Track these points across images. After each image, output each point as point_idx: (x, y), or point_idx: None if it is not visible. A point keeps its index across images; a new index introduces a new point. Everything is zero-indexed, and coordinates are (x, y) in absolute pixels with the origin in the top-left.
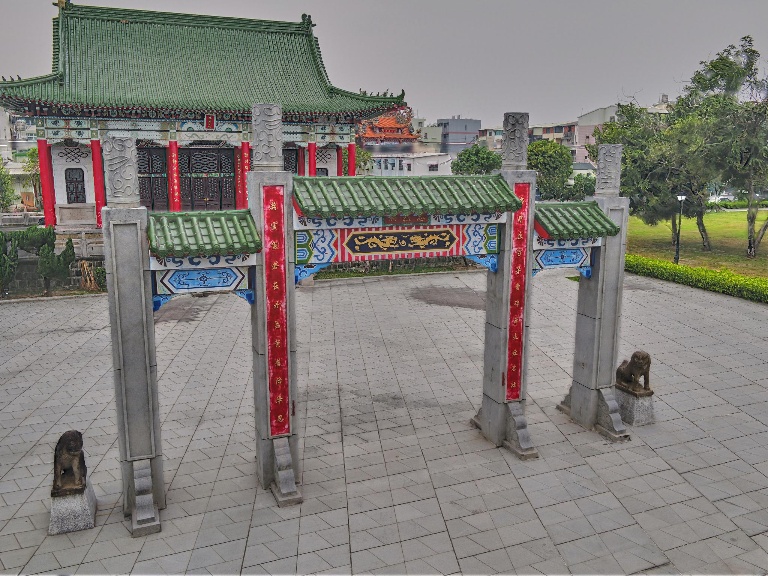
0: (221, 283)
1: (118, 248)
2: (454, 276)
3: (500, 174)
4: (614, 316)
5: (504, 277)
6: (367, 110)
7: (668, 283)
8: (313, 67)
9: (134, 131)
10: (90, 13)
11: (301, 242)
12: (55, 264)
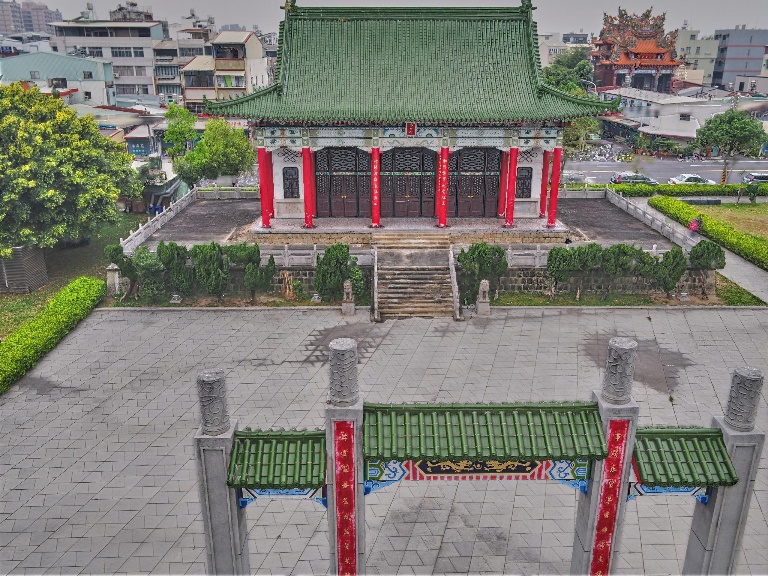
0: (298, 492)
1: (208, 466)
2: (647, 315)
3: (597, 403)
4: (731, 549)
5: (591, 505)
6: (576, 115)
7: None
8: (527, 59)
9: (340, 138)
10: (312, 14)
11: (373, 462)
12: (258, 280)
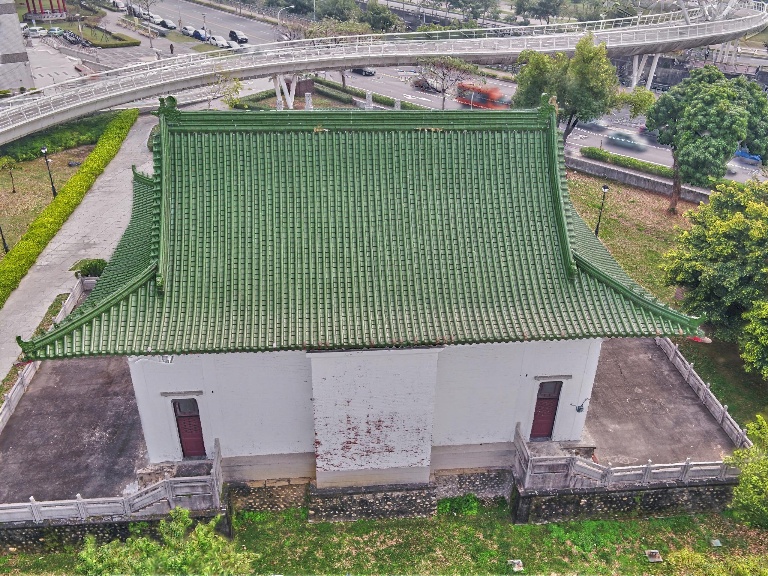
0: None
1: None
2: None
3: None
4: None
5: None
6: None
7: (49, 248)
8: None
9: None
10: (513, 119)
11: None
12: None
